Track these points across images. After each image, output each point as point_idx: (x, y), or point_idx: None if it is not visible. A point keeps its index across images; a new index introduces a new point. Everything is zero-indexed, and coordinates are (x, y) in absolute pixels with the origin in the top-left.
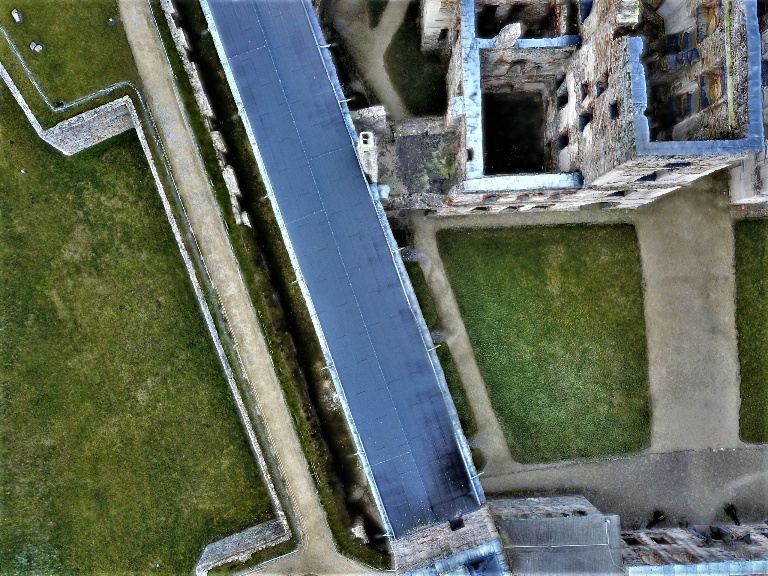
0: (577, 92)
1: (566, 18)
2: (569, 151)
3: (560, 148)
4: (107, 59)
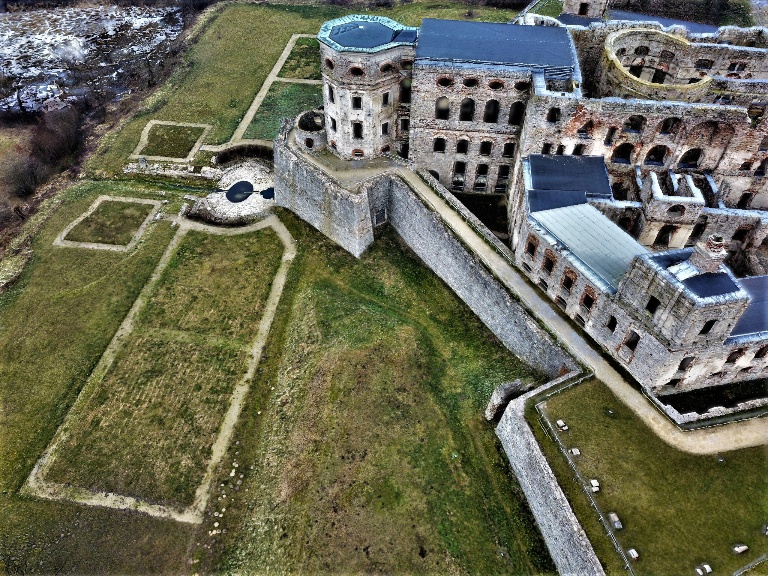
0: (740, 174)
1: (695, 173)
2: (762, 192)
3: (745, 207)
4: (761, 469)
